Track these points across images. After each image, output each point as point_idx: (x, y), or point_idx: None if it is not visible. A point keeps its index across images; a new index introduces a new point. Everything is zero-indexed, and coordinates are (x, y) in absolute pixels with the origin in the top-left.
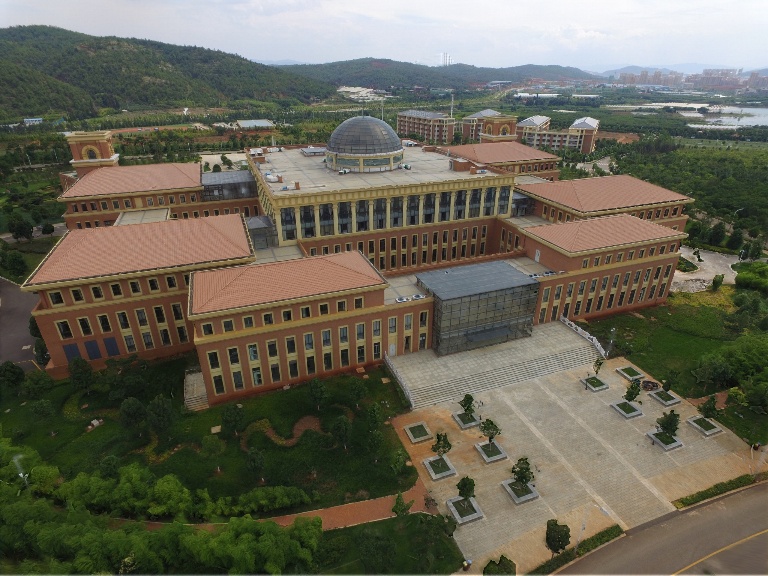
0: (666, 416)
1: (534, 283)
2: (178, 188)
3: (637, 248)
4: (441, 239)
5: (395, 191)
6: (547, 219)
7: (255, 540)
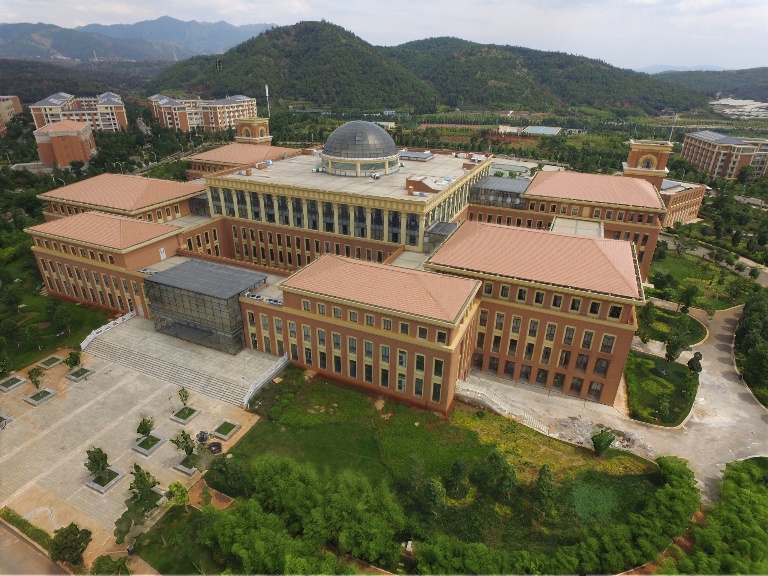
0: None
1: (222, 298)
2: None
3: (375, 314)
4: (343, 253)
5: (294, 192)
6: None
7: None
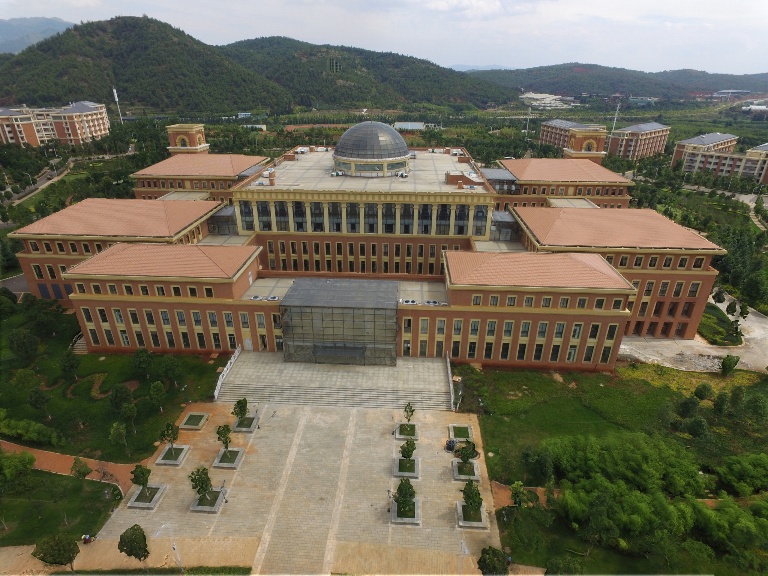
0: None
1: (389, 308)
2: (217, 176)
3: (554, 294)
4: (404, 252)
5: (350, 197)
6: (526, 248)
7: None
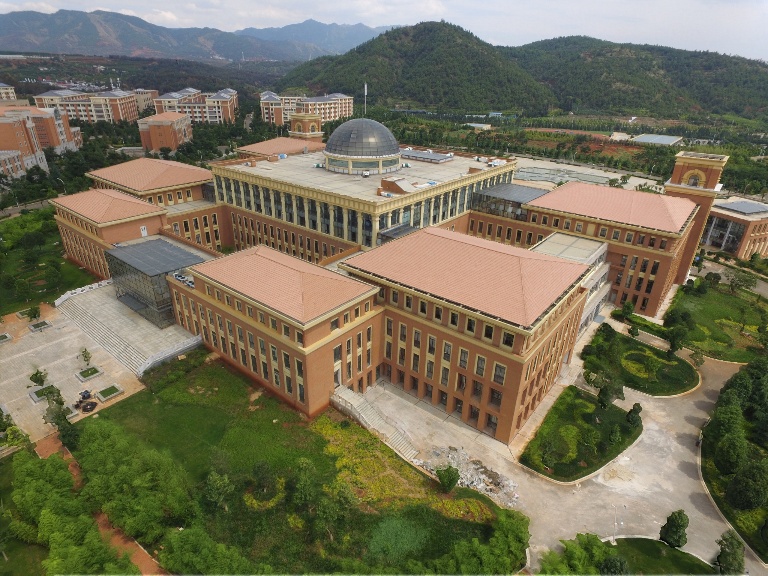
0: None
1: (148, 275)
2: None
3: (252, 306)
4: (313, 247)
5: (275, 184)
6: None
7: None
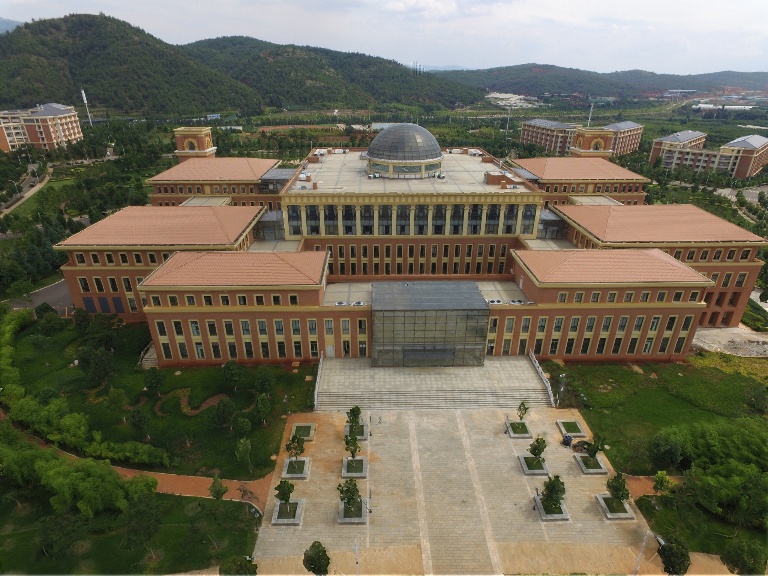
0: (549, 481)
1: (483, 309)
2: (239, 180)
3: (637, 289)
4: (452, 253)
5: (402, 199)
6: (576, 245)
7: (83, 479)
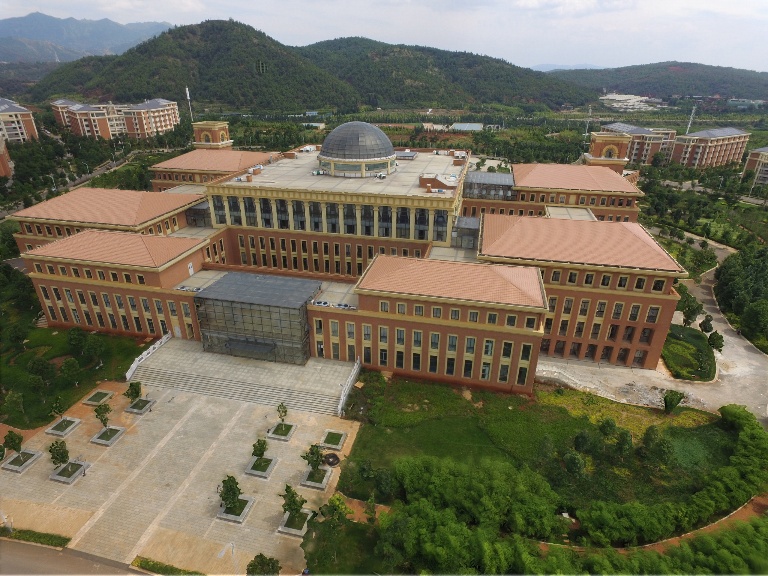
0: None
1: (293, 308)
2: (222, 171)
3: (462, 307)
4: (366, 254)
5: (312, 196)
6: None
7: None
